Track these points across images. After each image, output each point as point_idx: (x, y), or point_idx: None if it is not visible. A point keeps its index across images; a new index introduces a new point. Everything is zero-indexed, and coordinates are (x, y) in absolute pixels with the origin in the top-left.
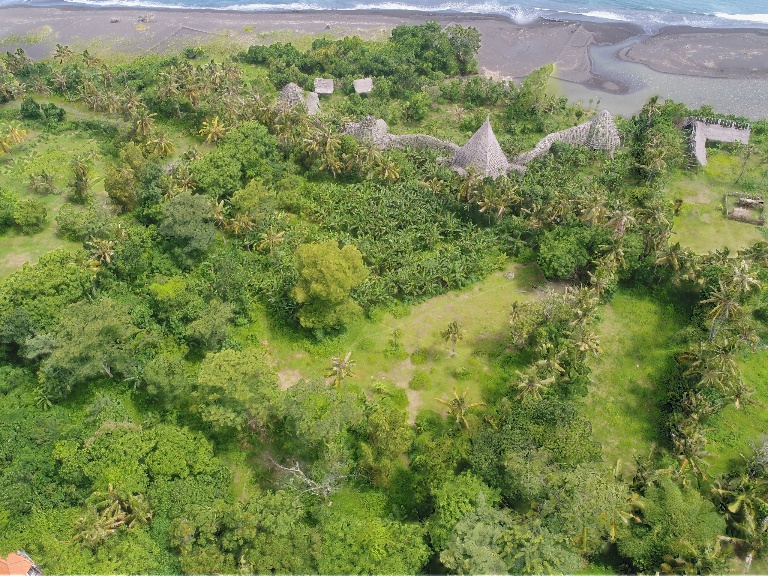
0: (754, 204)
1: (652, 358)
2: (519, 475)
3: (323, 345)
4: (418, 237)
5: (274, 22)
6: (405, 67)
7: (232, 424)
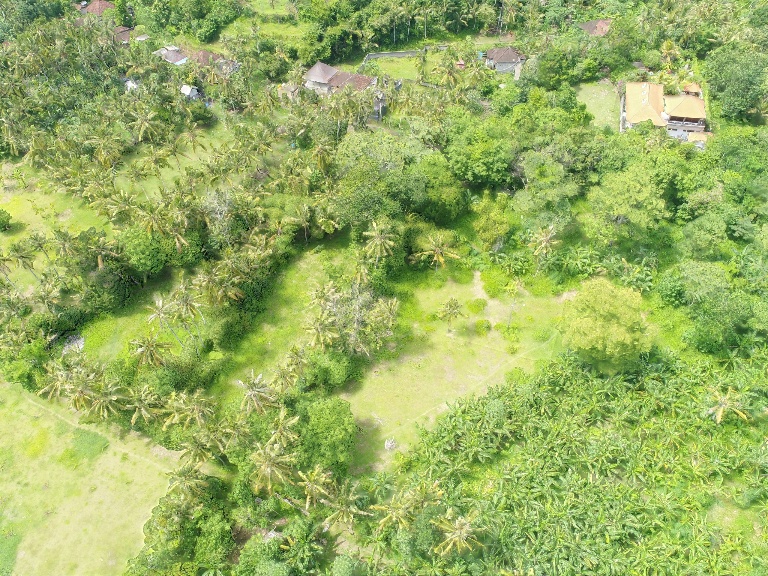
0: None
1: (254, 351)
2: None
3: None
4: None
5: None
6: None
7: None
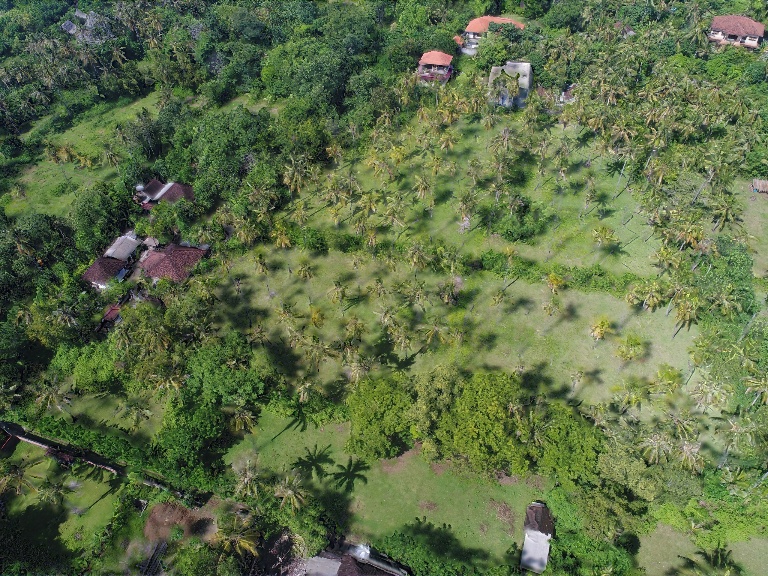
0: None
1: None
2: None
3: None
4: None
5: None
6: None
7: None
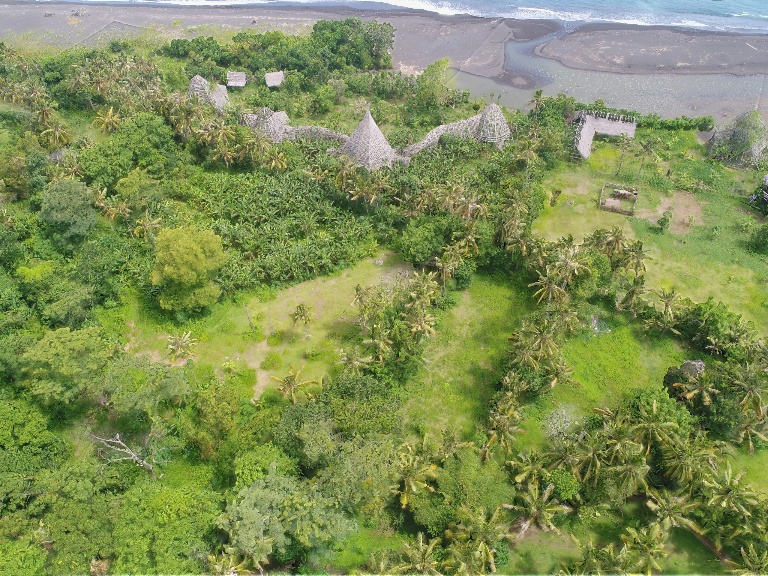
0: (627, 195)
1: (497, 341)
2: (306, 444)
3: (185, 327)
4: (294, 225)
5: (204, 17)
6: (314, 61)
7: (60, 398)
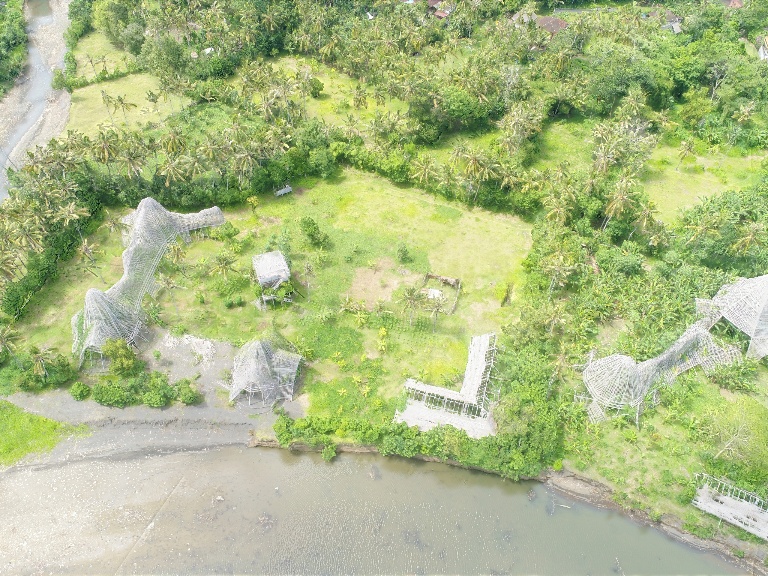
0: None
1: None
2: None
3: None
4: None
5: None
6: None
7: None
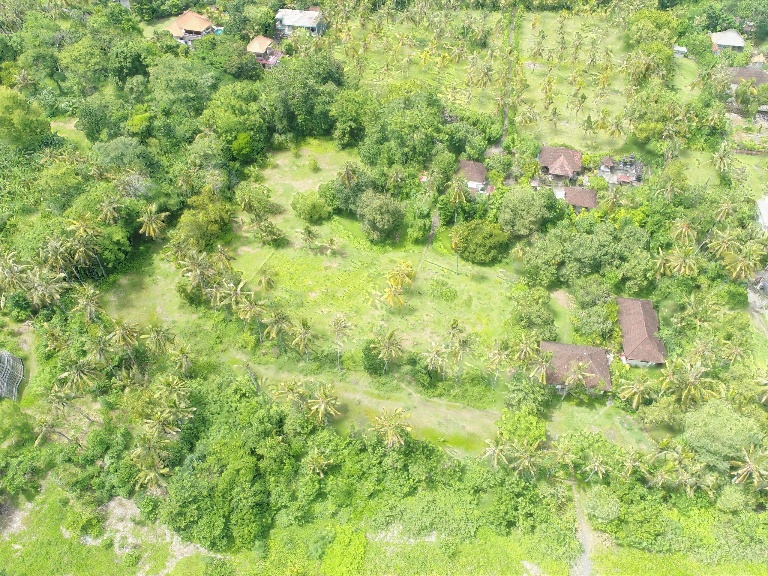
0: None
1: None
2: None
3: None
4: None
5: None
6: None
7: None
